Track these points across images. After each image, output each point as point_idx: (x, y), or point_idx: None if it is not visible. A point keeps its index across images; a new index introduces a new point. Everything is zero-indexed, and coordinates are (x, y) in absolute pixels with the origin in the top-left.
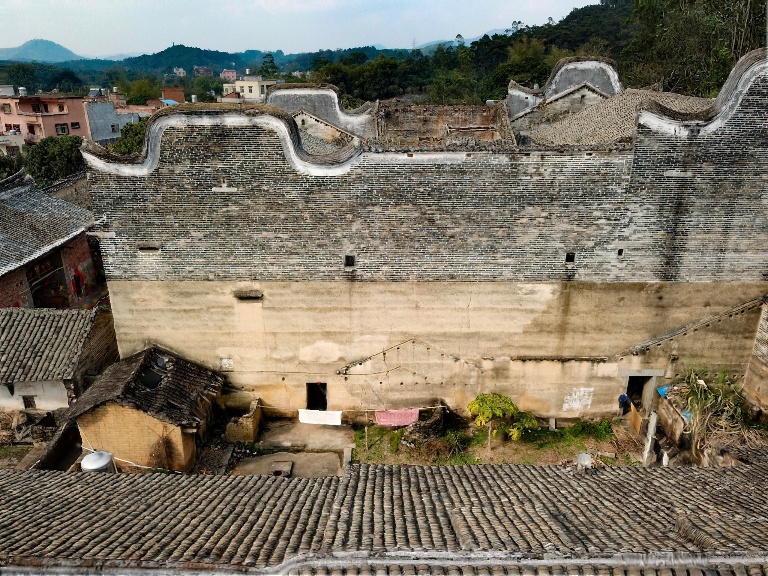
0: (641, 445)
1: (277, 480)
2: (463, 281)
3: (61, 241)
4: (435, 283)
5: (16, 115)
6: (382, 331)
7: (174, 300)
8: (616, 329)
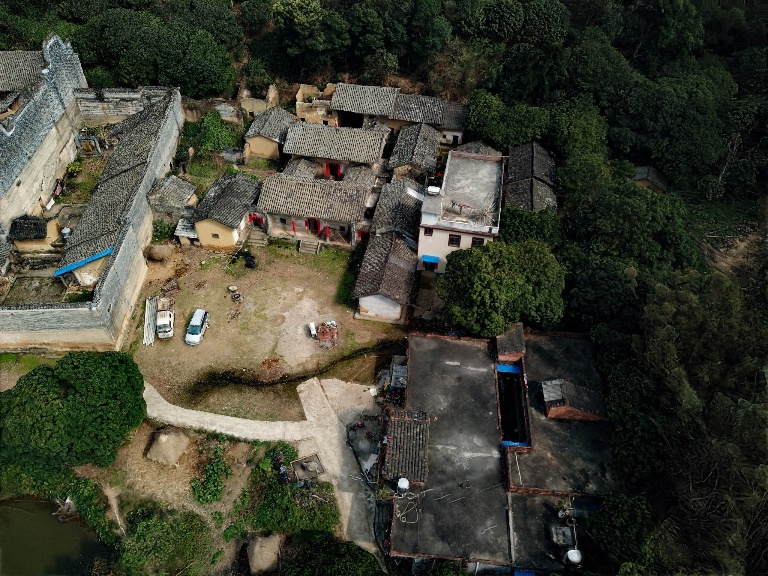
0: (91, 153)
1: None
2: (43, 140)
3: None
4: (40, 145)
5: None
6: (40, 169)
7: (8, 200)
8: (66, 129)
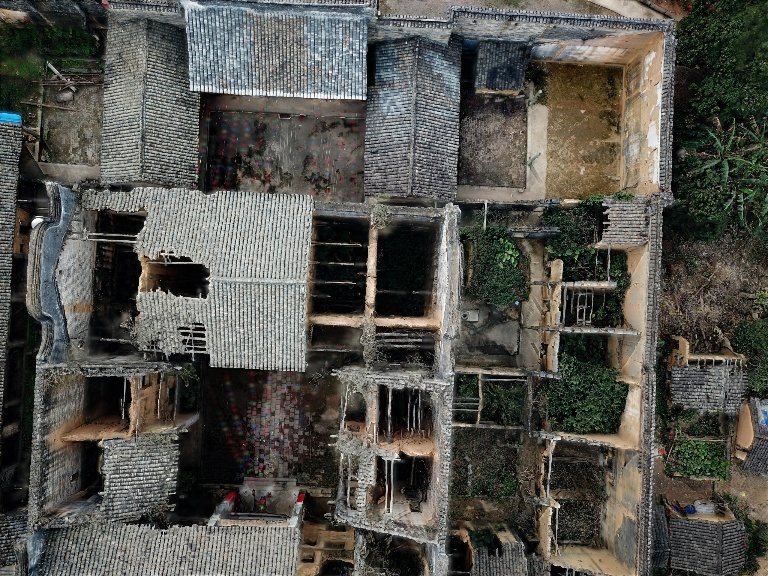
0: None
1: (1, 310)
2: None
3: (279, 94)
4: None
5: None
6: None
7: None
8: None
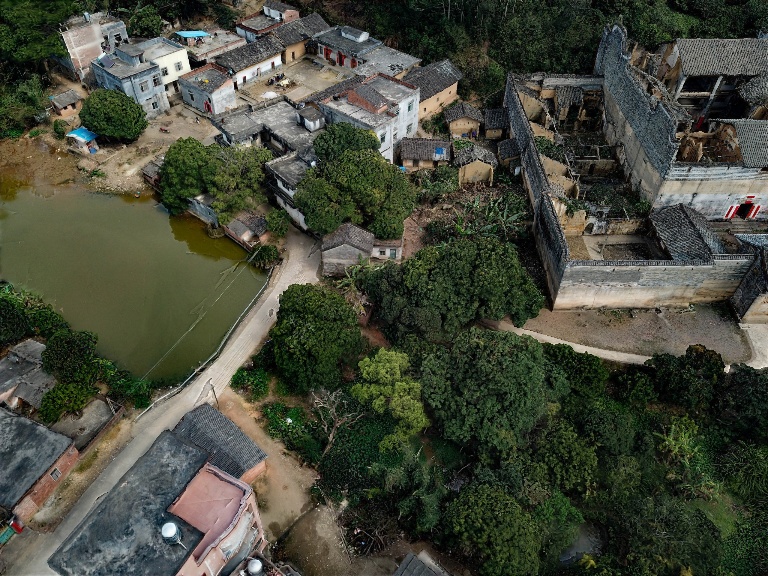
0: None
1: None
2: None
3: None
4: None
5: (194, 572)
6: None
7: None
8: None
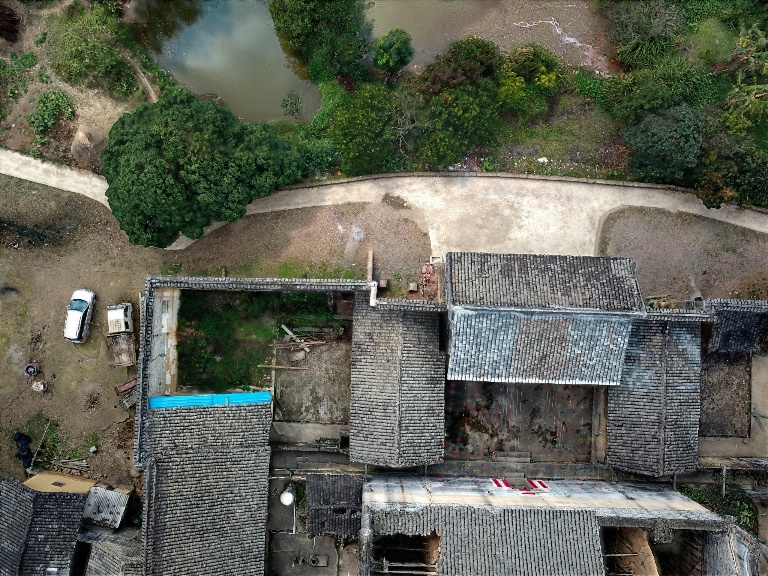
0: None
1: None
2: None
3: (534, 381)
4: None
5: None
6: None
7: None
8: None
